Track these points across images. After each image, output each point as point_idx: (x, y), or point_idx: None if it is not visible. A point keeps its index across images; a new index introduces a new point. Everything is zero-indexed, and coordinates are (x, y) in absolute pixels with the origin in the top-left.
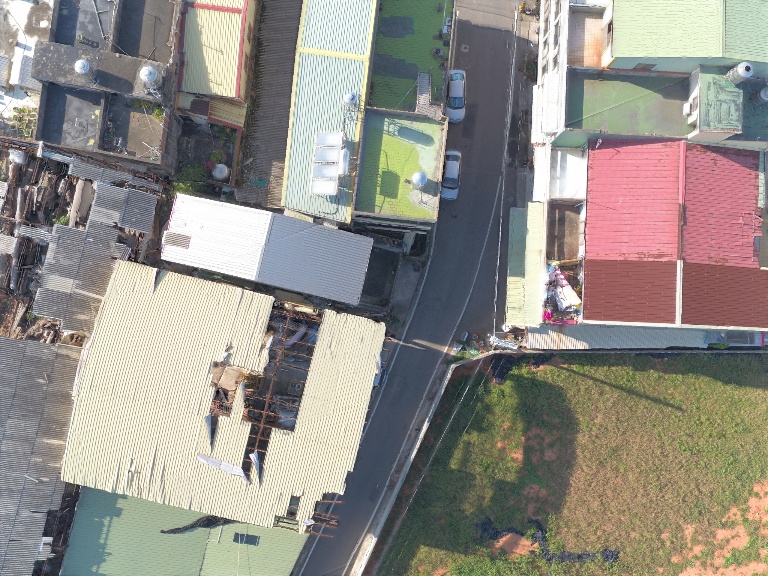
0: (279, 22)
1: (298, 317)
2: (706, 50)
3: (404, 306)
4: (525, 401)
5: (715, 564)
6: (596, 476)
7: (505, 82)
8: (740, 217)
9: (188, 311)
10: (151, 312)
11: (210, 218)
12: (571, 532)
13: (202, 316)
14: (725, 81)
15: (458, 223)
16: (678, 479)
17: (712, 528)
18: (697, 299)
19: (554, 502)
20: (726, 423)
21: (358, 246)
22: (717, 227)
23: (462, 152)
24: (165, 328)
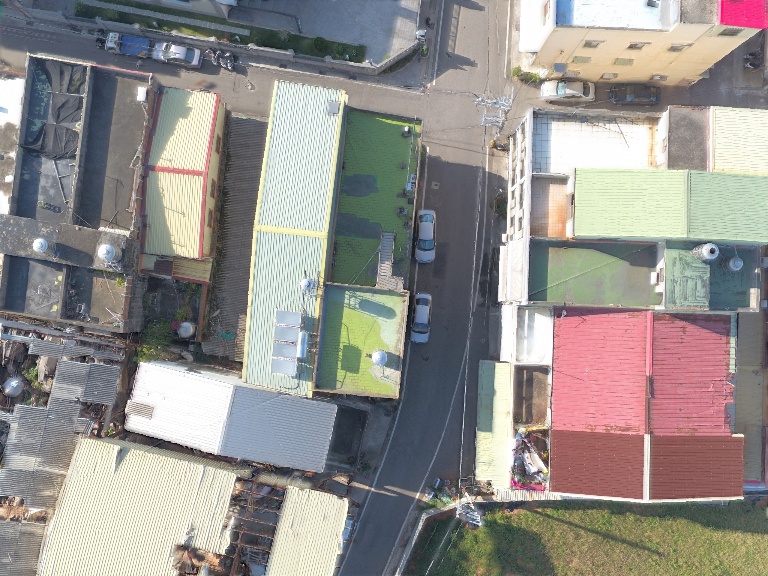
0: (244, 171)
1: (260, 495)
2: (670, 230)
3: (375, 452)
4: (498, 547)
5: None
6: None
7: None
8: (710, 384)
9: (149, 492)
10: (112, 494)
11: (172, 389)
12: None
13: (163, 497)
14: (691, 256)
15: (429, 366)
16: None
17: None
18: (665, 473)
19: None
20: (704, 566)
21: (322, 414)
22: (686, 397)
23: (433, 293)
24: (126, 511)
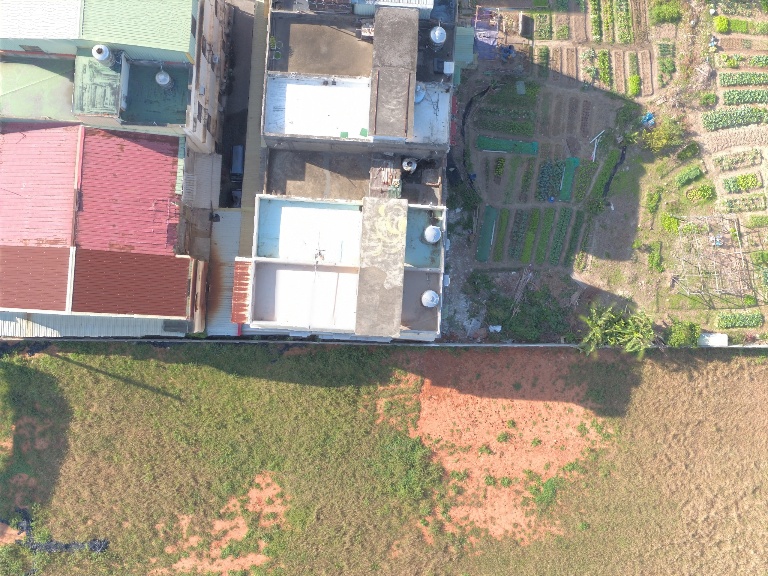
0: None
1: None
2: (65, 32)
3: None
4: (14, 389)
5: (212, 555)
6: (87, 465)
7: None
8: (152, 204)
9: None
10: None
11: None
12: (58, 521)
13: None
14: None
15: None
16: (173, 469)
17: (209, 519)
18: (92, 286)
19: (43, 491)
20: (227, 413)
21: None
22: (122, 213)
23: None
24: None
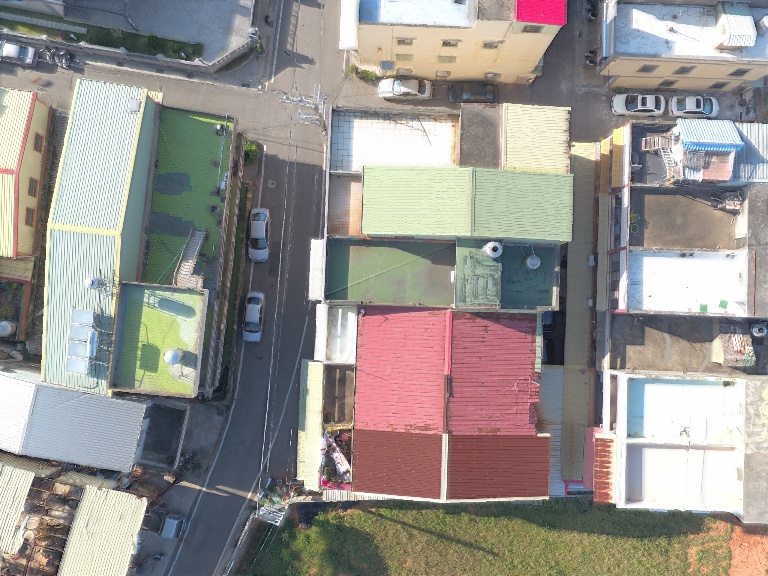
0: None
1: (57, 494)
2: (455, 228)
3: (207, 451)
4: (330, 547)
5: None
6: None
7: (313, 218)
8: (514, 384)
9: None
10: None
11: None
12: None
13: None
14: (482, 255)
15: (263, 365)
16: None
17: None
18: (464, 473)
19: None
20: (539, 566)
21: (129, 413)
22: (488, 396)
23: (268, 292)
24: None
